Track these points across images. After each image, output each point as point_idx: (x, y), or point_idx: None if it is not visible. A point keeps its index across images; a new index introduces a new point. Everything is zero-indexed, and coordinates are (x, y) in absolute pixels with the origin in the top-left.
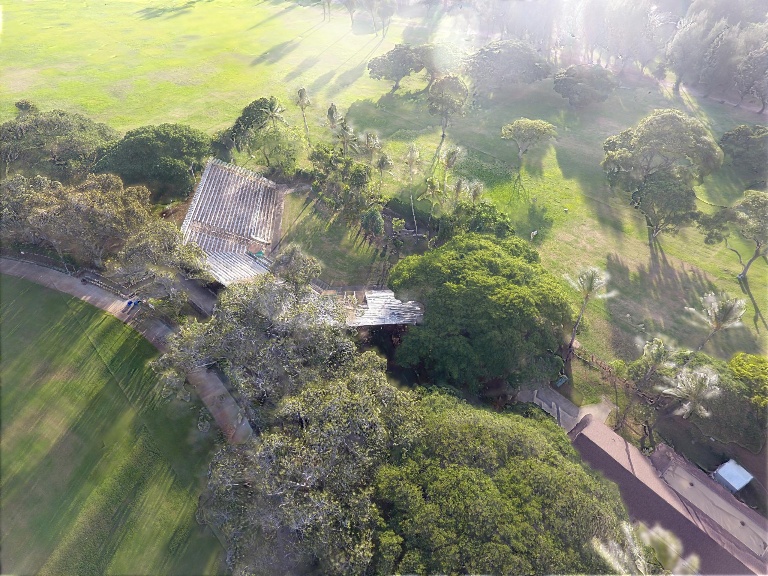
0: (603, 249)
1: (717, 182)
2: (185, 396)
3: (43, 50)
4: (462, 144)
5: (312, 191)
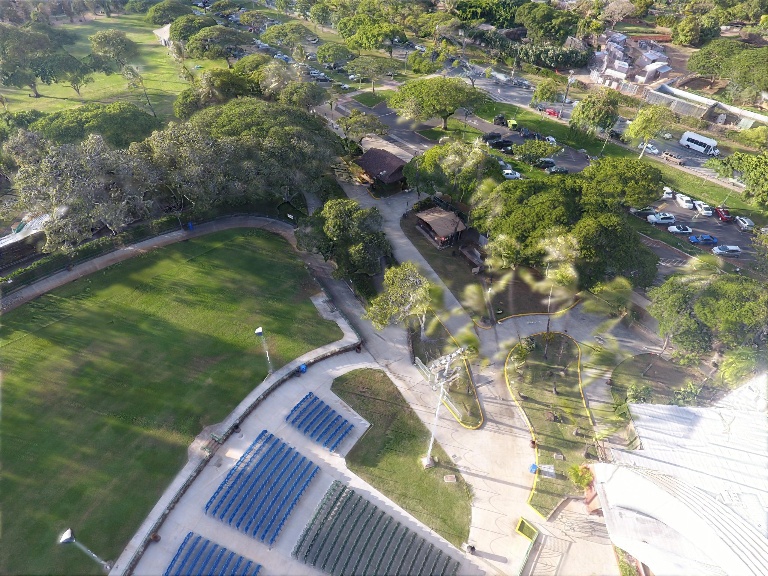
0: None
1: None
2: (120, 205)
3: None
4: None
5: None
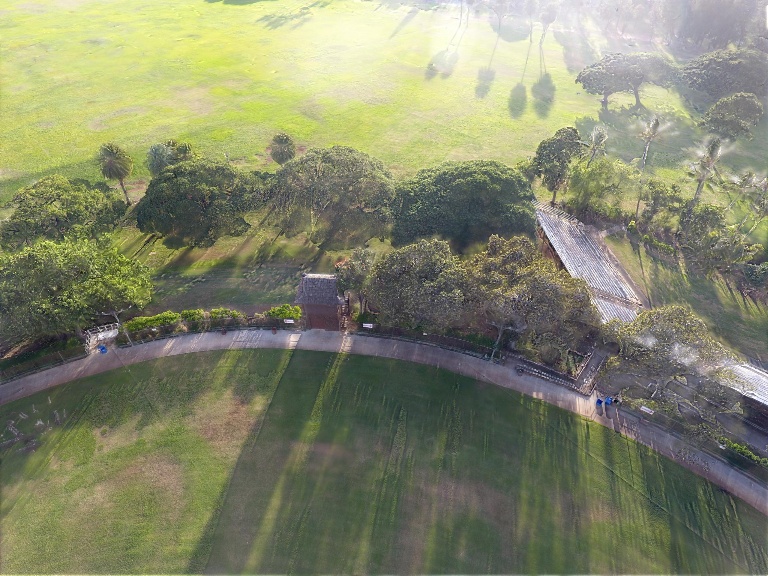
0: None
1: None
2: None
3: (194, 66)
4: (739, 170)
5: (629, 233)
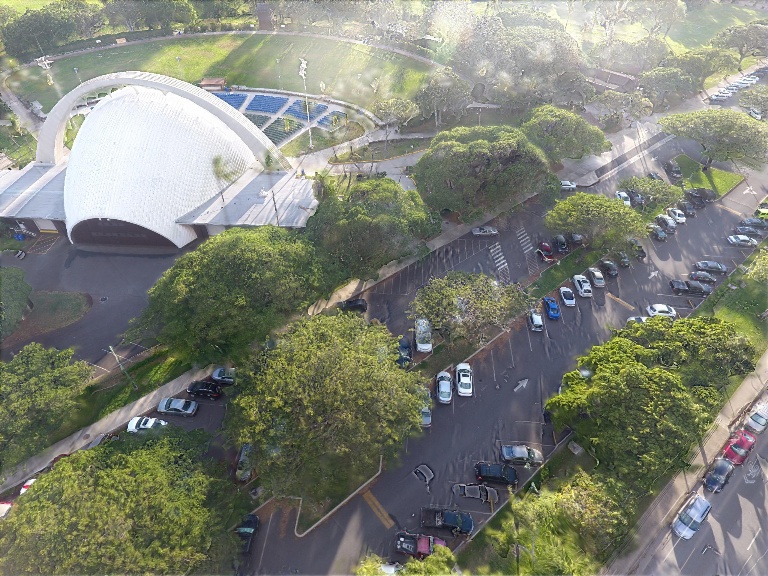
0: (581, 39)
1: (648, 19)
2: None
3: None
4: None
5: None
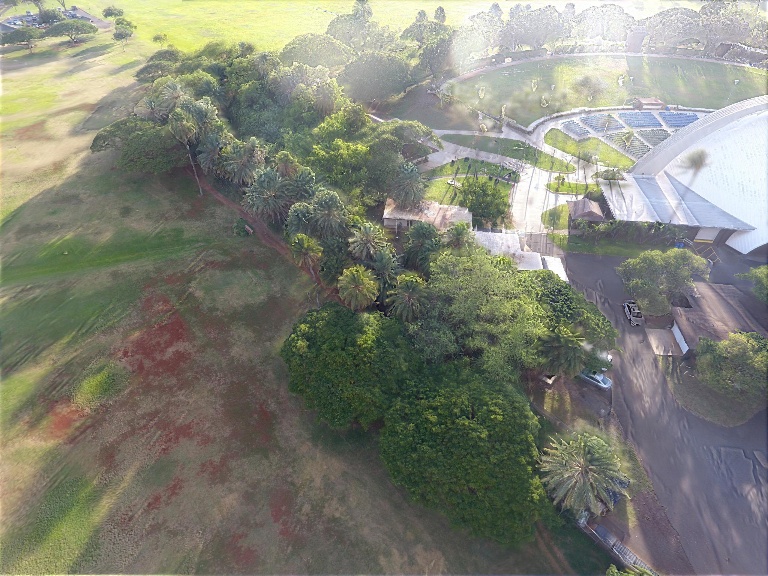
0: None
1: None
2: None
3: None
4: None
5: None
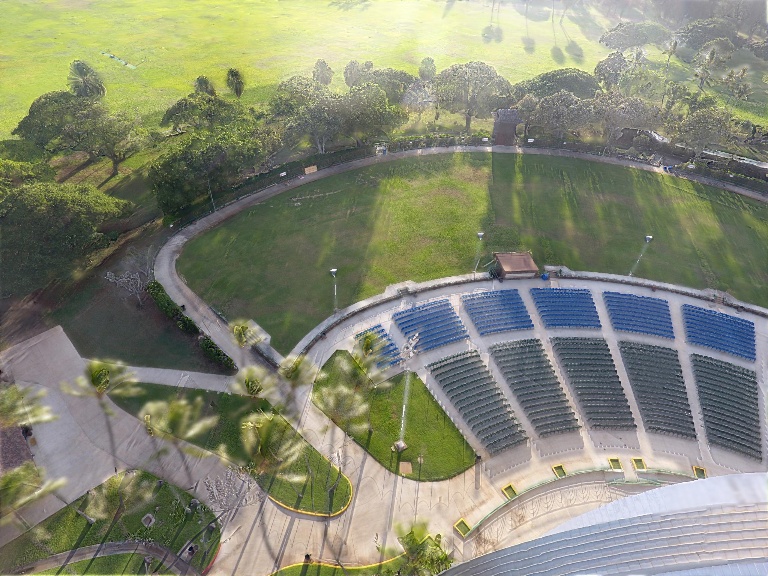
0: None
1: None
2: None
3: (303, 33)
4: (719, 92)
5: None
